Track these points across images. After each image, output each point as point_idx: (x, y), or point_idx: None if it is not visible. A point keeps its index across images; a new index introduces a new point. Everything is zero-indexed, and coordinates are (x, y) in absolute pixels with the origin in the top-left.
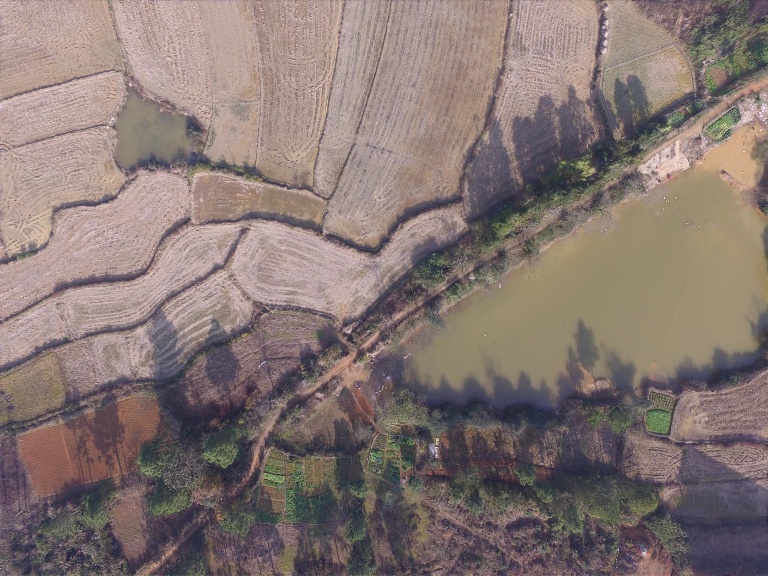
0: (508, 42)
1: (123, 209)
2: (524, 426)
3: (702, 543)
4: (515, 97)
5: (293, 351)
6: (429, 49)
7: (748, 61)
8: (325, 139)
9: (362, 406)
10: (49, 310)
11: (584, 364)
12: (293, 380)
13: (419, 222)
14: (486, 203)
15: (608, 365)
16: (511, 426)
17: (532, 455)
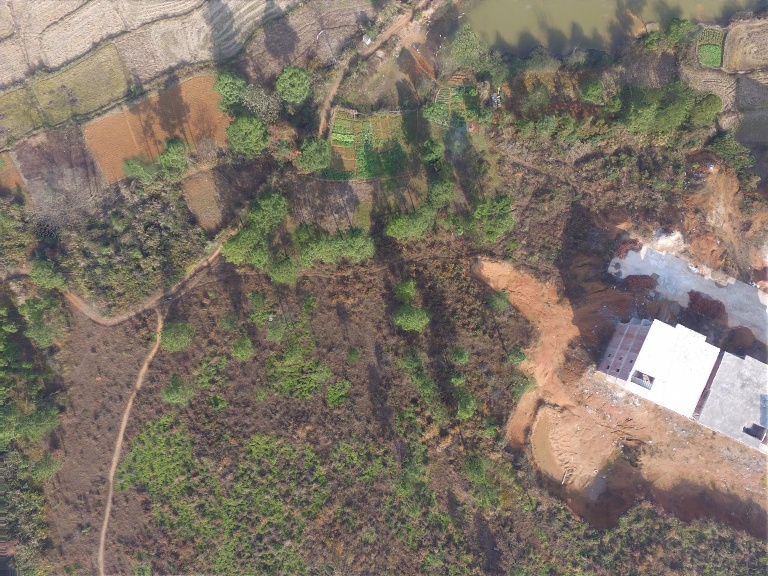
0: None
1: None
2: (583, 59)
3: (764, 164)
4: None
5: (349, 19)
6: None
7: None
8: None
9: (422, 65)
10: (103, 6)
11: (633, 10)
12: None
13: None
14: None
15: (656, 10)
16: (572, 53)
17: None
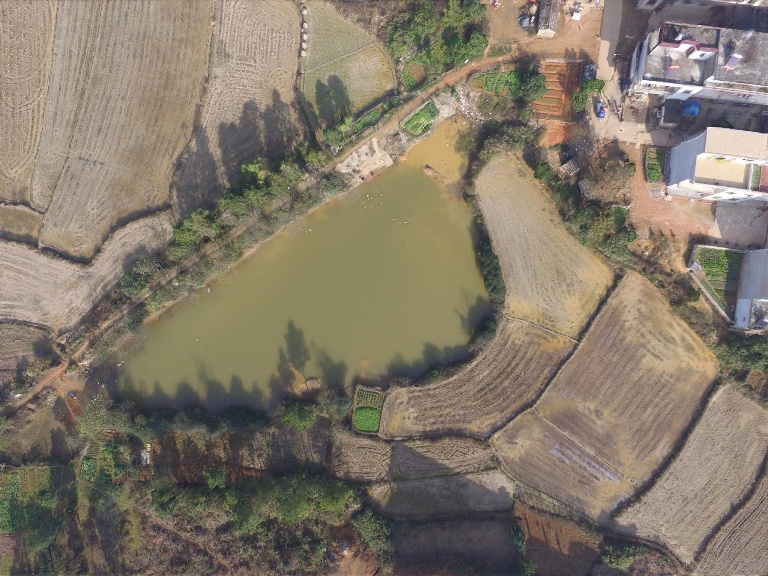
0: (212, 50)
1: None
2: (224, 429)
3: (412, 540)
4: (220, 104)
5: (10, 363)
6: (137, 61)
7: (444, 55)
8: (40, 155)
9: None
10: None
11: (295, 364)
12: (6, 392)
13: (130, 231)
14: None
15: (319, 364)
16: None
17: (242, 457)
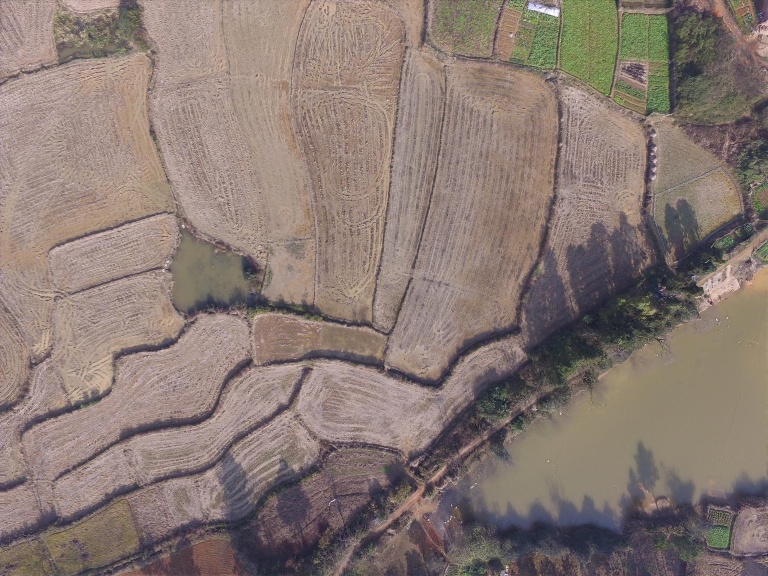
0: (559, 171)
1: (184, 353)
2: (592, 553)
3: None
4: (568, 226)
5: (362, 487)
6: (481, 180)
7: None
8: (382, 274)
9: (432, 537)
10: (116, 457)
11: (644, 484)
12: (364, 518)
13: (479, 354)
14: (543, 332)
15: (667, 484)
16: (581, 557)
17: None
